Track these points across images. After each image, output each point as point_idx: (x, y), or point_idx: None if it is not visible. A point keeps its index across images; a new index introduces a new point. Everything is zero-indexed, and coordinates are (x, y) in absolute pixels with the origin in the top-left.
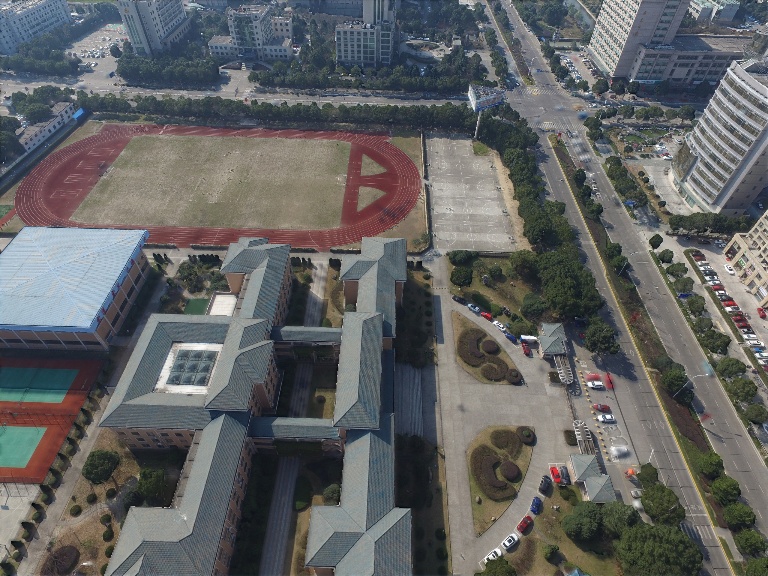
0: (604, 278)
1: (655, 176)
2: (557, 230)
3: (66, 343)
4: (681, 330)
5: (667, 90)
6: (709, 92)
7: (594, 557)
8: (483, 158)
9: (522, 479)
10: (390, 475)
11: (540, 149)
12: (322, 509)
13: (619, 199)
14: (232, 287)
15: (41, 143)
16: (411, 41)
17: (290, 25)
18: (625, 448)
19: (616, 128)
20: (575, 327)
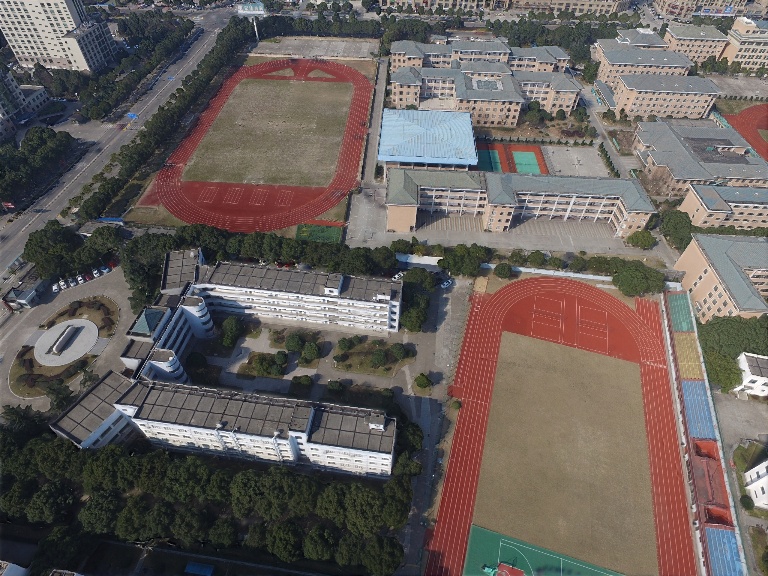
0: None
1: None
2: None
3: None
4: None
5: None
6: None
7: None
8: (284, 41)
9: None
10: None
11: None
12: (539, 58)
13: None
14: None
15: None
16: None
17: None
18: None
19: None
20: None
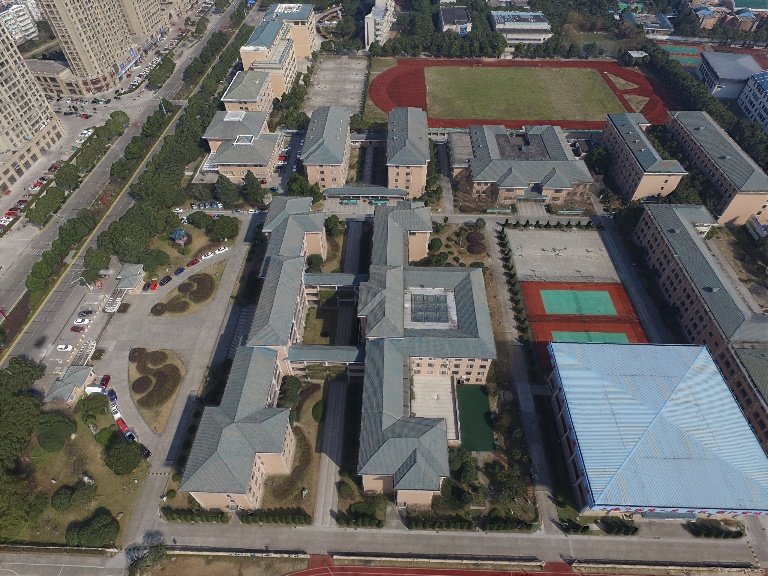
0: None
1: None
2: None
3: None
4: None
5: None
6: None
7: None
8: None
9: None
10: None
11: None
12: (316, 229)
13: None
14: None
15: None
16: None
17: None
18: (86, 303)
19: None
20: None
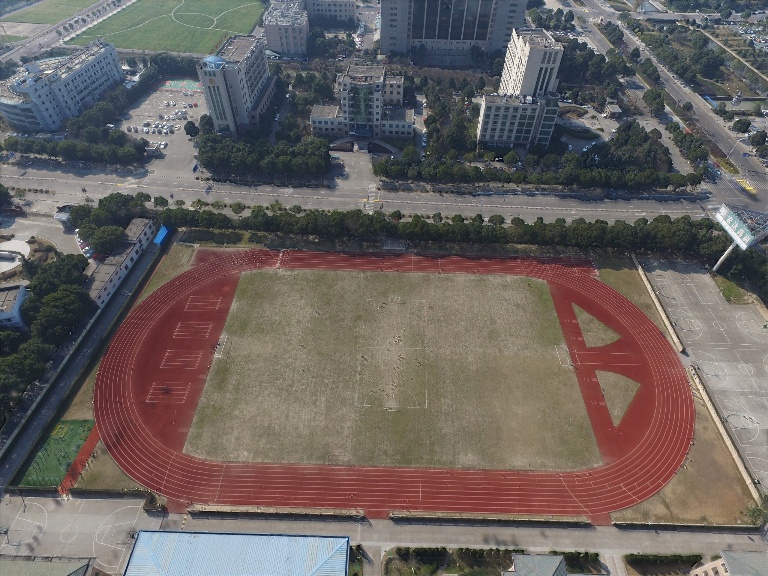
0: None
1: None
2: None
3: None
4: None
5: None
6: None
7: None
8: (743, 309)
9: None
10: None
11: None
12: None
13: None
14: None
15: (116, 288)
16: None
17: (402, 87)
18: None
19: None
20: None
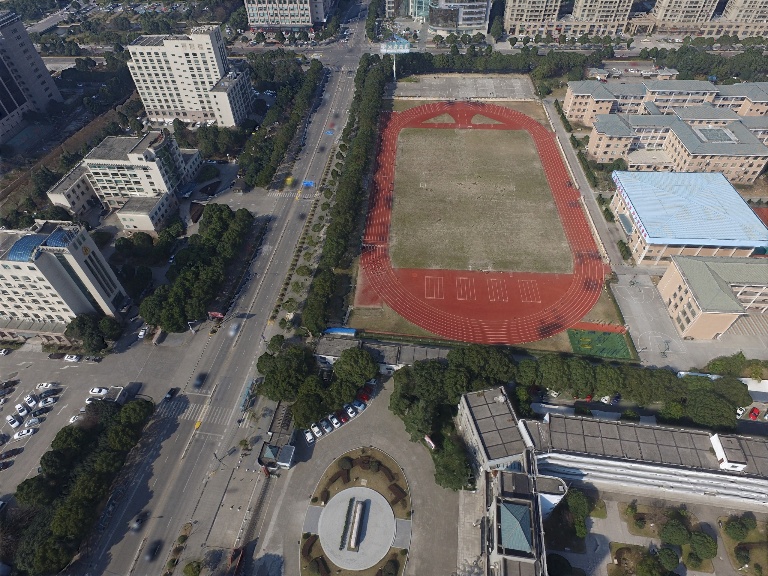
0: None
1: None
2: None
3: None
4: None
5: None
6: None
7: None
8: (423, 80)
9: None
10: None
11: None
12: None
13: (465, 49)
14: None
15: None
16: None
17: None
18: None
19: None
20: None
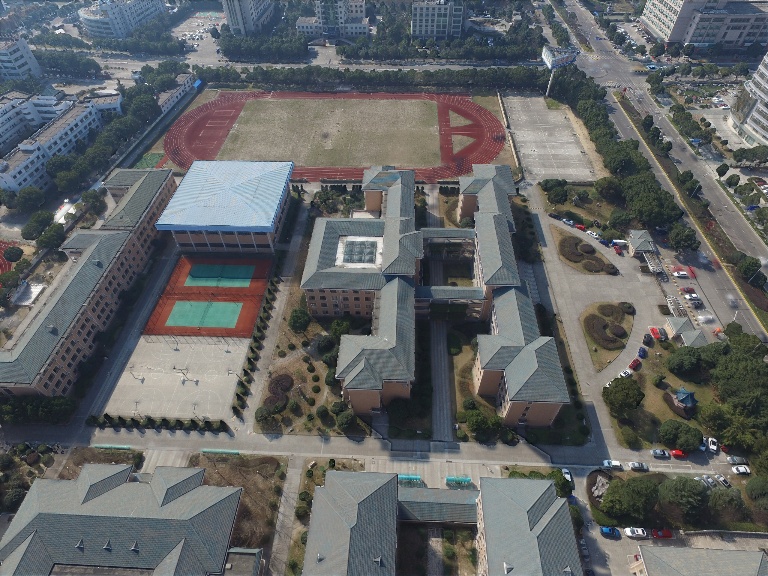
0: (678, 200)
1: (715, 122)
2: (635, 161)
3: (242, 246)
4: (750, 237)
5: (720, 51)
6: (760, 52)
7: (694, 385)
8: (556, 111)
9: (628, 336)
10: (533, 316)
11: (607, 103)
12: (486, 336)
13: (684, 141)
14: (367, 205)
15: (172, 107)
16: (473, 18)
17: (364, 7)
18: (711, 317)
19: (675, 85)
20: (657, 235)
